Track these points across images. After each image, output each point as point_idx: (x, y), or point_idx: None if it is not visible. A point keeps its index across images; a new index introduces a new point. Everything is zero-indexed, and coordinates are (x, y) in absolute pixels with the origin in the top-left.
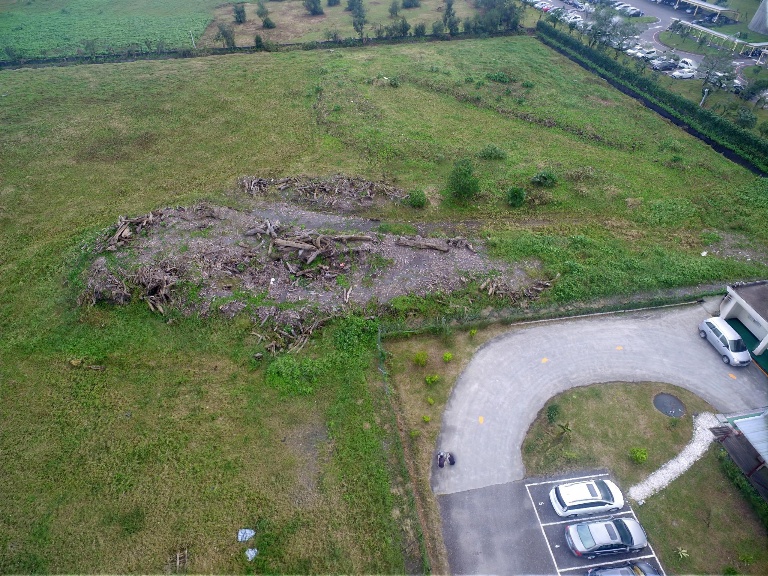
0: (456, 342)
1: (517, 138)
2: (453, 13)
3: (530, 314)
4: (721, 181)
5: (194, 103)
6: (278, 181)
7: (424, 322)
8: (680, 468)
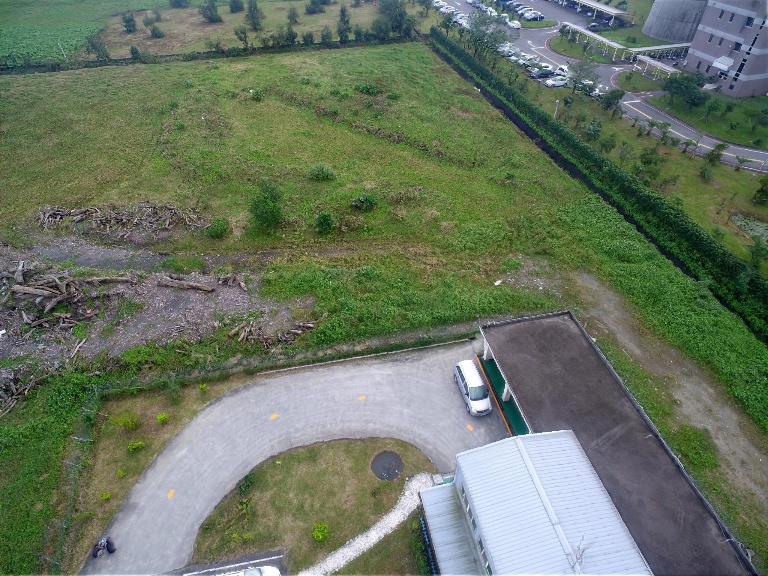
0: (186, 398)
1: (359, 156)
2: (347, 20)
3: (283, 361)
4: (549, 199)
5: (35, 123)
6: (74, 212)
7: (161, 375)
8: (365, 544)
